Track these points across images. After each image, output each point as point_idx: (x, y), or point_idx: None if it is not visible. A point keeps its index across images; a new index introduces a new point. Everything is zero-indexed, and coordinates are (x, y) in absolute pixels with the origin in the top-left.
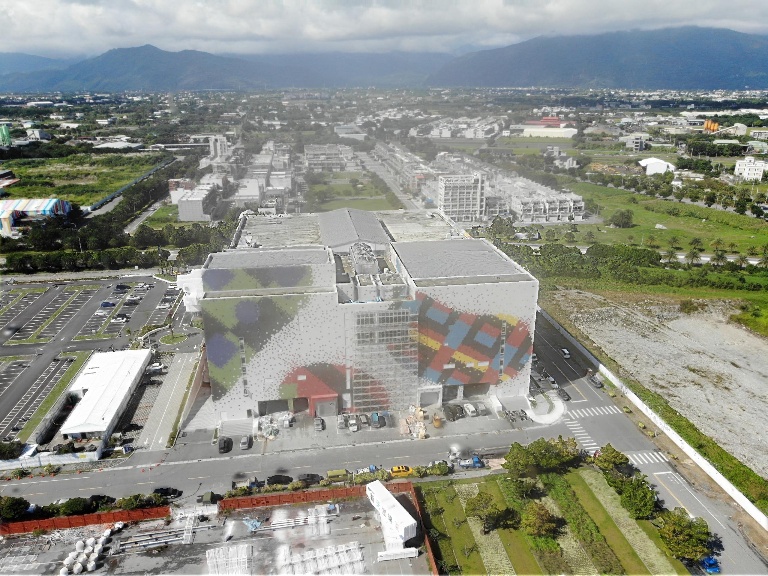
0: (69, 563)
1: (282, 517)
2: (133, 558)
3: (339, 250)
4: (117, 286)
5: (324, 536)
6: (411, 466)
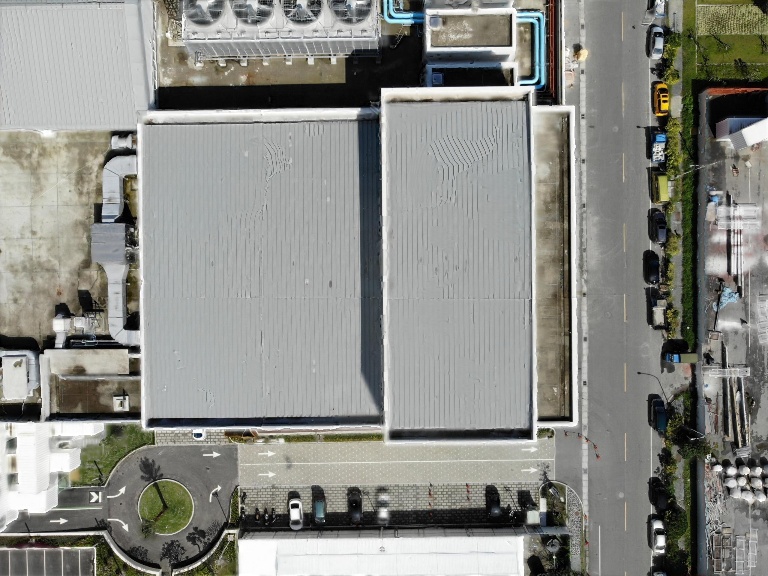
0: (765, 496)
1: (720, 263)
2: (759, 428)
3: (151, 84)
4: None
5: (759, 212)
6: (647, 86)
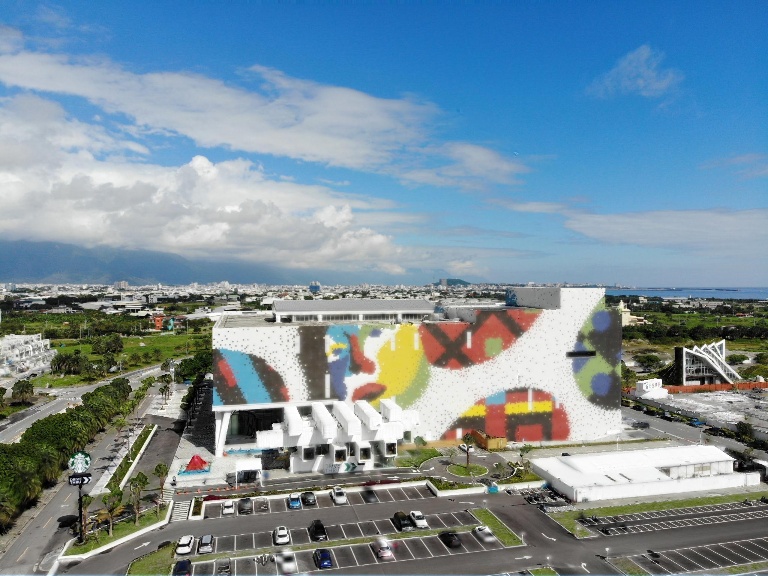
0: None
1: None
2: None
3: None
4: (187, 570)
5: None
6: None
